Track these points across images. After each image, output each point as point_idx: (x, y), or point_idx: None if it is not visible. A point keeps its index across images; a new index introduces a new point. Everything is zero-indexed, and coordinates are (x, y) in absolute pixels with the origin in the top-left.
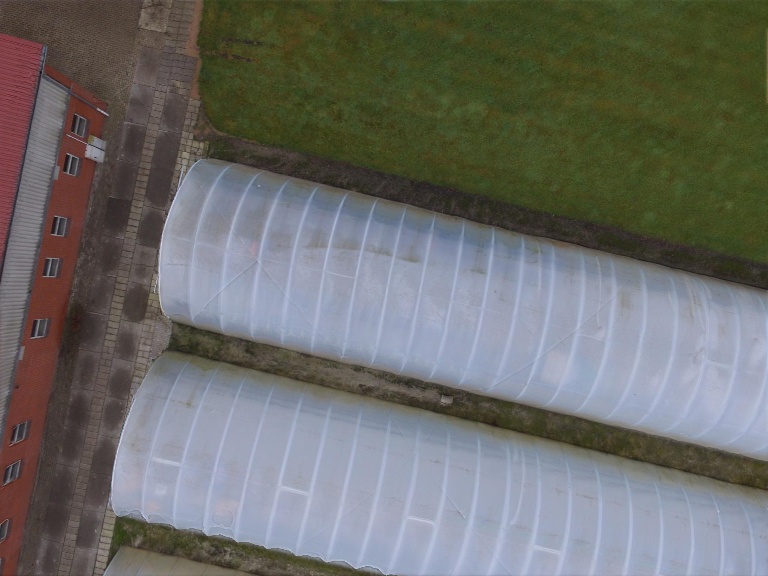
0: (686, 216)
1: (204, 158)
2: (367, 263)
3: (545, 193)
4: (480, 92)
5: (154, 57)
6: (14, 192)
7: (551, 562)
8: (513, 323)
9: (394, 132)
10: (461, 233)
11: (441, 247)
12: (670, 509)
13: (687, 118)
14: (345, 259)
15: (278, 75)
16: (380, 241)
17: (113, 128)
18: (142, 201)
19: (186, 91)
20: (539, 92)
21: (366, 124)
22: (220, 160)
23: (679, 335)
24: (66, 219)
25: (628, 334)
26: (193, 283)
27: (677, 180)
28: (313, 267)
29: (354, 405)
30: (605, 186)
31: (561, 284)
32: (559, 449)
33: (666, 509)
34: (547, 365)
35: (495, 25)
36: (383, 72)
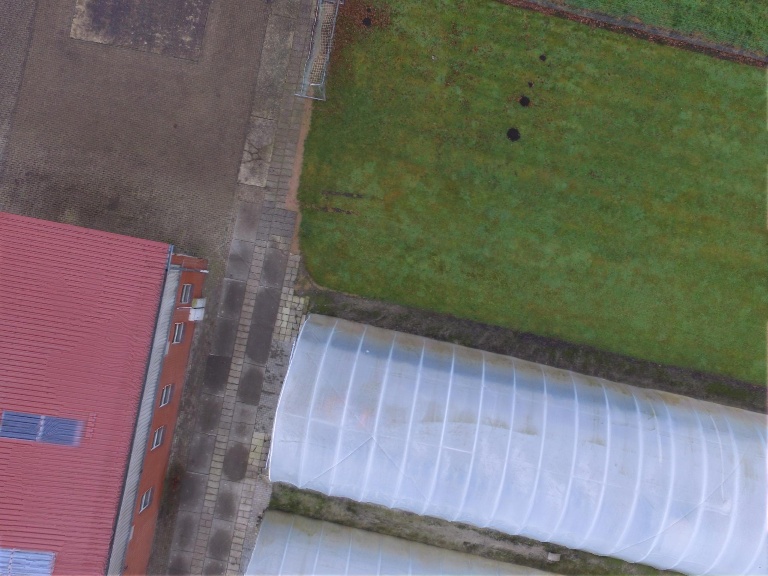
0: None
1: (304, 313)
2: (484, 438)
3: (651, 343)
4: (583, 242)
5: (254, 212)
6: (139, 391)
7: None
8: (635, 498)
9: (496, 283)
10: (575, 398)
11: (557, 416)
12: None
13: None
14: (462, 434)
15: (378, 227)
16: (496, 413)
17: (213, 284)
18: (242, 358)
19: (286, 246)
20: (643, 241)
21: (467, 275)
22: (321, 315)
23: None
24: (170, 385)
25: (754, 508)
26: (306, 459)
27: None
28: (429, 442)
29: (462, 569)
30: (712, 335)
31: (682, 454)
32: None
33: None
34: (667, 536)
35: (597, 173)
36: (484, 223)
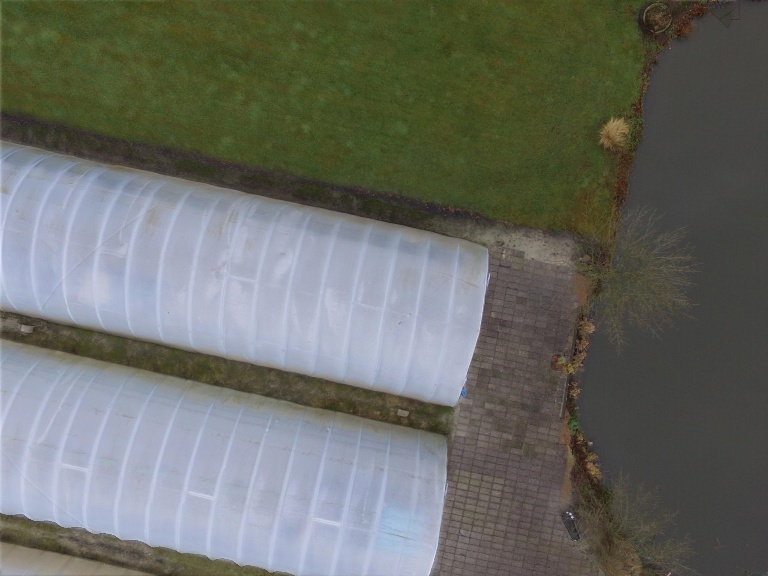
0: (263, 142)
1: None
2: None
3: (122, 122)
4: (54, 23)
5: None
6: None
7: (79, 480)
8: (34, 242)
9: None
10: (2, 157)
11: None
12: (215, 428)
13: (260, 44)
14: None
15: None
16: None
17: None
18: None
19: None
20: (112, 22)
21: None
22: None
23: (202, 251)
24: None
25: (150, 251)
26: None
27: (252, 106)
28: None
29: None
30: (181, 114)
31: (89, 203)
32: (130, 375)
33: (210, 428)
34: None
35: None
36: None
